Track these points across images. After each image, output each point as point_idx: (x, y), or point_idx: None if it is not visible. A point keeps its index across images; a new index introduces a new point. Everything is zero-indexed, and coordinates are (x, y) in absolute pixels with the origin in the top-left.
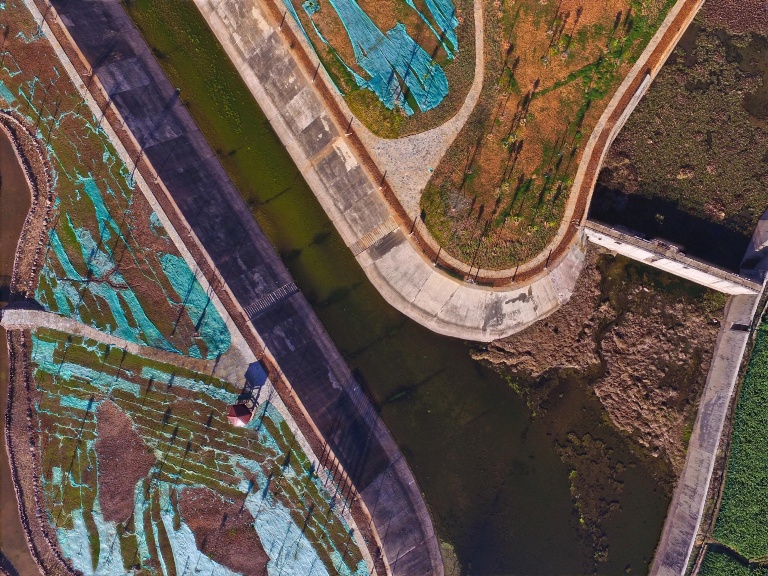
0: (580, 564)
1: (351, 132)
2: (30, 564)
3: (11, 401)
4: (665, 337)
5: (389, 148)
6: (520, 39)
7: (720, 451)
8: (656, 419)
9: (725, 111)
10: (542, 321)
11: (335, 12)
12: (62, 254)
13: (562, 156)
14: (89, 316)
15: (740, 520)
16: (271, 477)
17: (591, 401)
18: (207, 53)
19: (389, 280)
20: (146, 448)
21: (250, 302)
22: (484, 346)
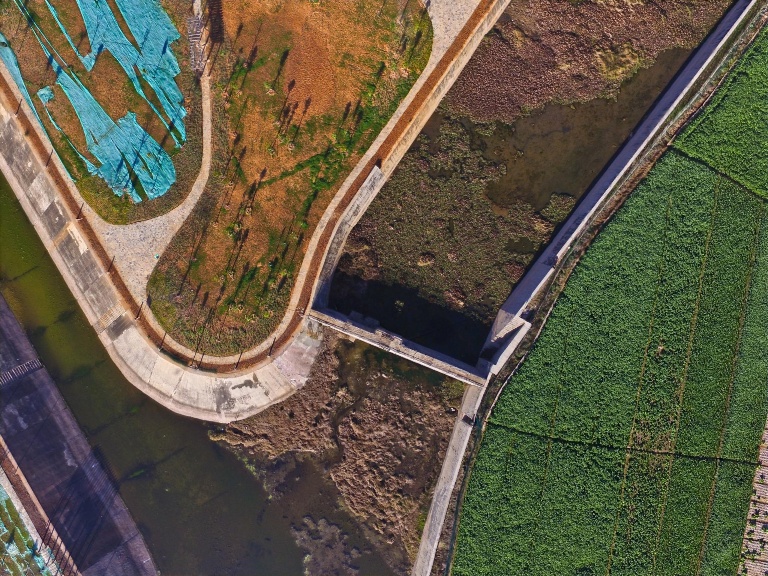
0: None
1: (82, 217)
2: None
3: None
4: (402, 424)
5: (118, 234)
6: (247, 129)
7: (444, 544)
8: (391, 506)
9: (467, 199)
10: (277, 405)
11: (68, 100)
12: None
13: (288, 245)
14: None
15: None
16: None
17: (328, 485)
18: None
19: (126, 360)
20: None
21: None
22: (222, 427)
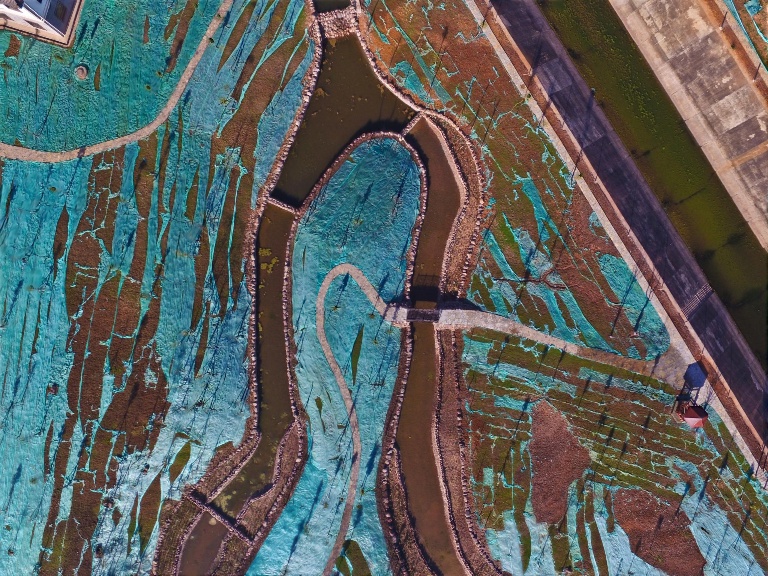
0: None
1: None
2: (455, 565)
3: (440, 401)
4: None
5: None
6: None
7: None
8: None
9: None
10: None
11: None
12: (499, 254)
13: None
14: (527, 316)
15: None
16: (708, 479)
17: None
18: (622, 53)
19: None
20: (581, 449)
21: (684, 303)
22: None
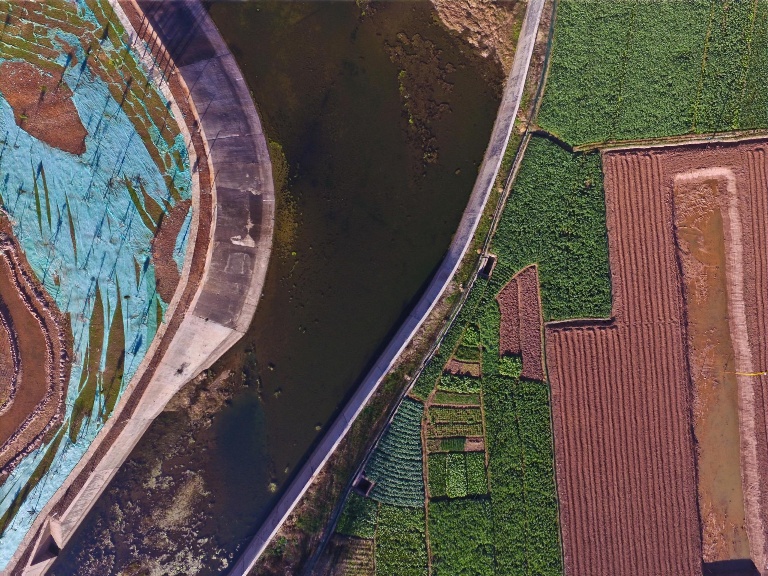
0: (410, 167)
1: None
2: None
3: None
4: None
5: None
6: None
7: (543, 35)
8: (485, 18)
9: None
10: None
11: None
12: None
13: None
14: None
15: (562, 104)
16: (89, 51)
17: (421, 1)
18: None
19: None
20: None
21: None
22: None
